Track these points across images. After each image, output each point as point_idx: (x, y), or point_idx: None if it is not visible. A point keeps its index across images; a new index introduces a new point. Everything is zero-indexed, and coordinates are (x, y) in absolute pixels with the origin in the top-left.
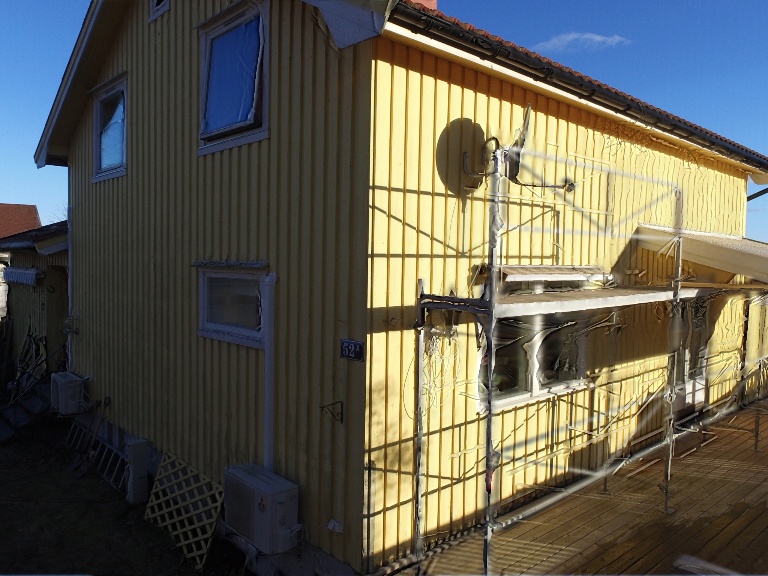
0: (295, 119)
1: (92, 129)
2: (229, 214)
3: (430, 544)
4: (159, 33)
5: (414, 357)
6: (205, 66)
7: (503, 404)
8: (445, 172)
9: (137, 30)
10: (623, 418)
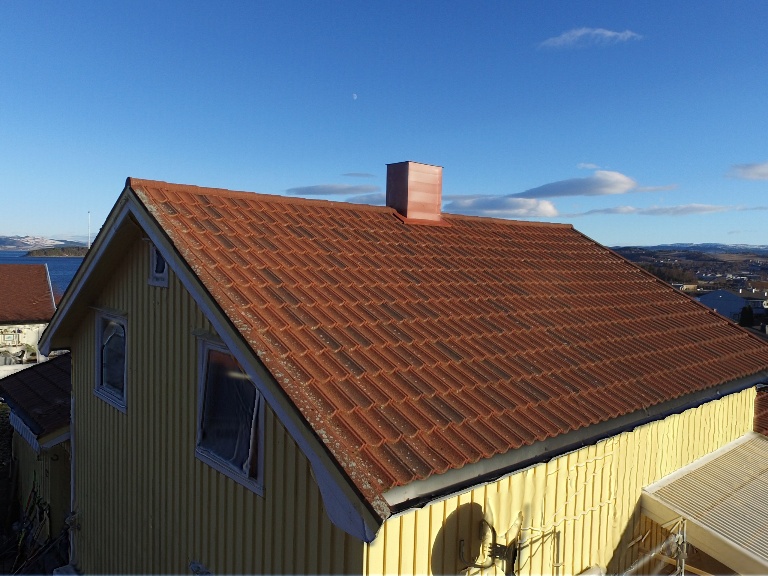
0: (289, 502)
1: (94, 340)
2: (225, 539)
3: None
4: (158, 303)
5: None
6: (202, 372)
7: None
8: (440, 570)
9: (137, 280)
10: None
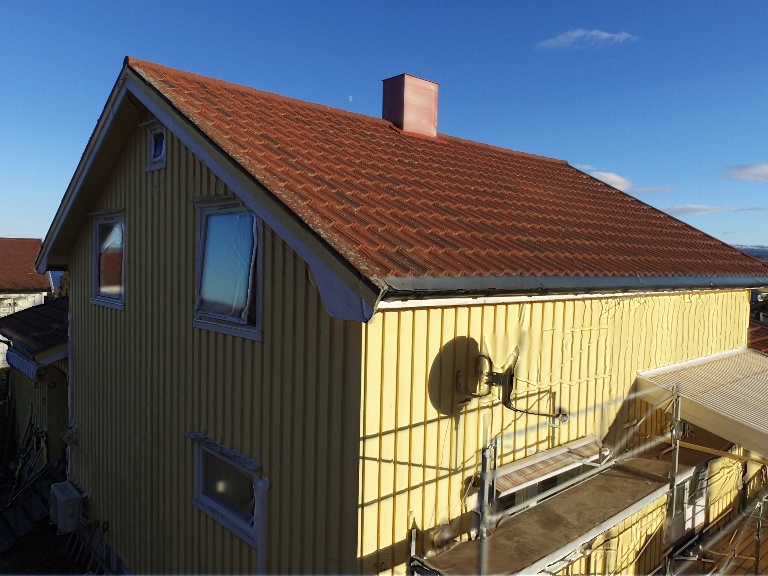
0: (288, 336)
1: (91, 249)
2: (223, 398)
3: None
4: (156, 186)
5: None
6: (200, 240)
7: None
8: (438, 397)
9: (135, 172)
10: (620, 570)
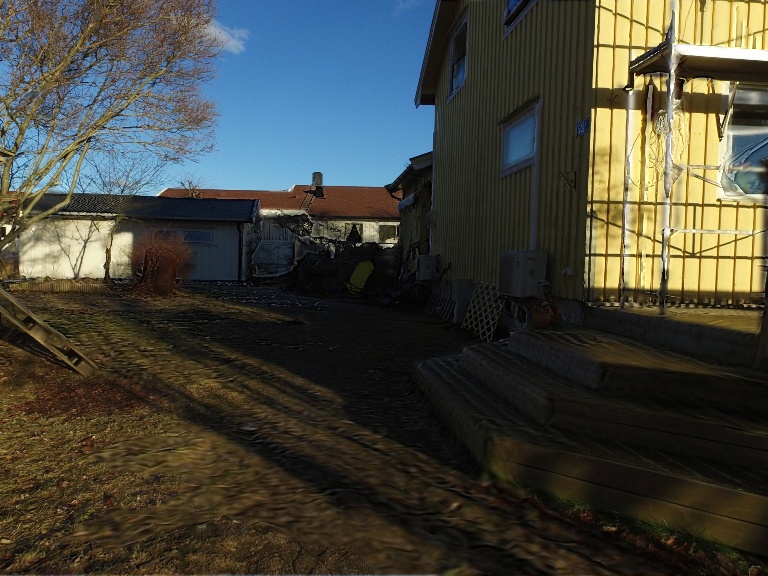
0: None
1: (449, 64)
2: (519, 72)
3: (656, 302)
4: None
5: (641, 134)
6: None
7: (755, 199)
8: None
9: None
10: None
